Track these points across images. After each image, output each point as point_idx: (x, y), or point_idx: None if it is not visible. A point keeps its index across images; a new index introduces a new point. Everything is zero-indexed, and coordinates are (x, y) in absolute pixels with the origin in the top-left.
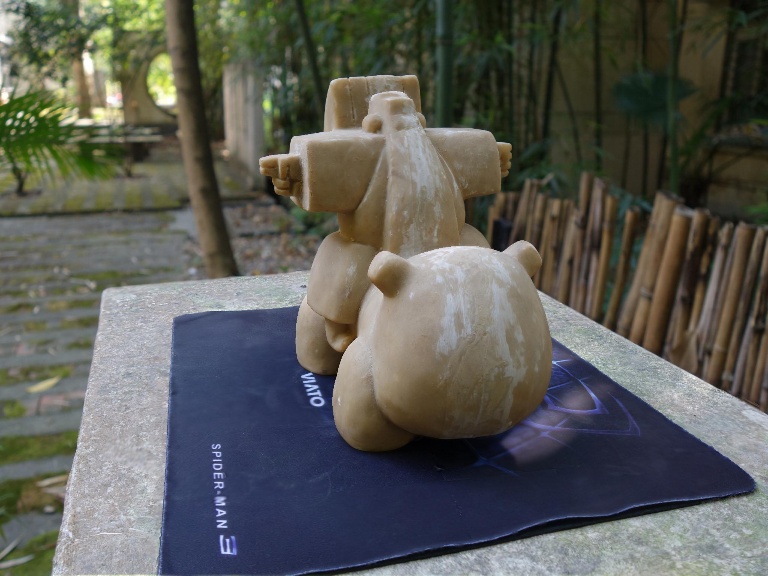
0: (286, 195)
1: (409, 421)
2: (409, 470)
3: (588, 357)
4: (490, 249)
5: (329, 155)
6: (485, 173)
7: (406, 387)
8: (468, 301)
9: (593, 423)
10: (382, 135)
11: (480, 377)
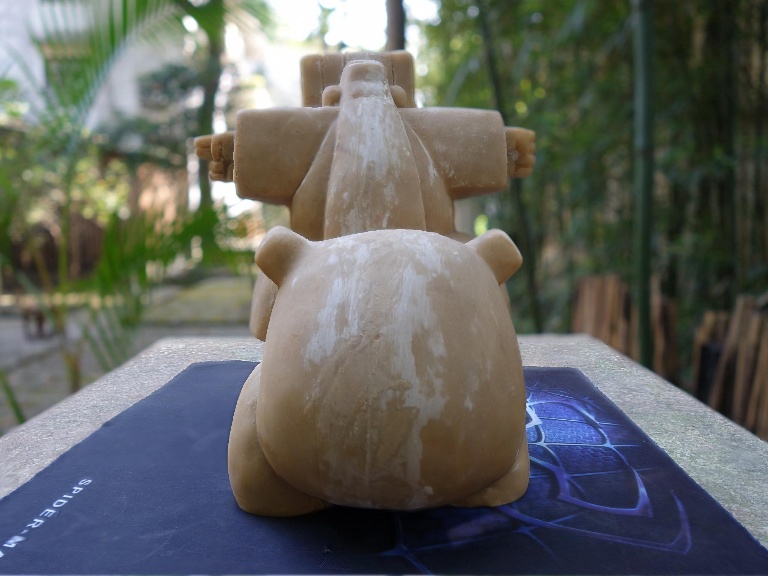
0: None
1: (282, 467)
2: (284, 545)
3: (672, 447)
4: None
5: (261, 126)
6: (482, 159)
7: (271, 411)
8: (362, 288)
9: (615, 526)
10: (338, 107)
11: (363, 402)
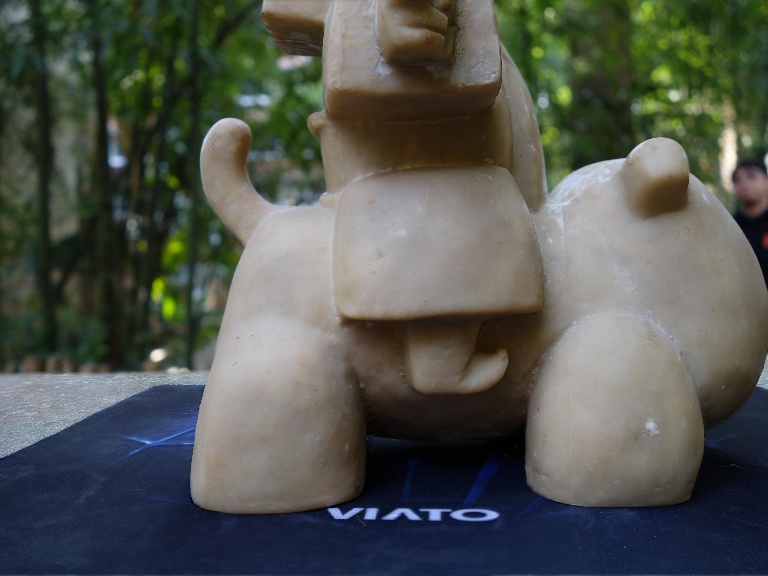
0: (438, 50)
1: (744, 394)
2: (745, 480)
3: None
4: None
5: None
6: None
7: (757, 332)
8: None
9: None
10: None
11: None
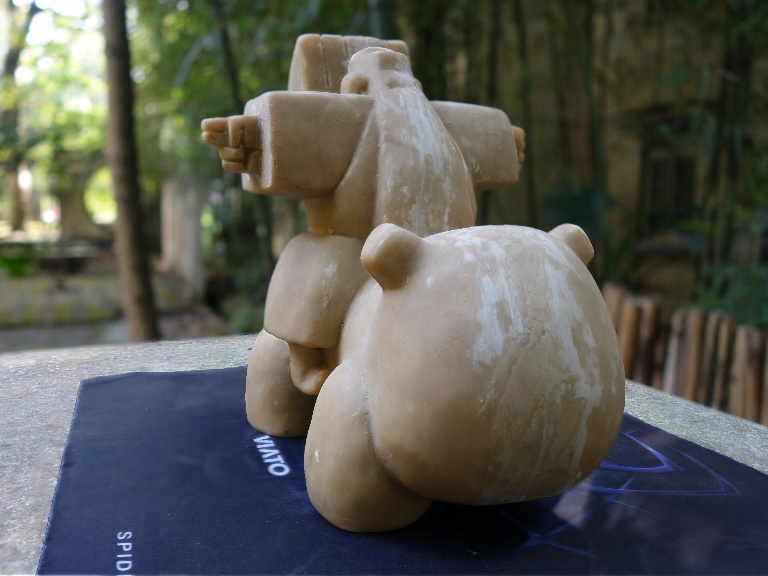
0: (238, 170)
1: (429, 476)
2: (430, 557)
3: None
4: None
5: (299, 111)
6: (499, 156)
7: (426, 420)
8: (514, 286)
9: (670, 482)
10: (369, 95)
11: (540, 398)
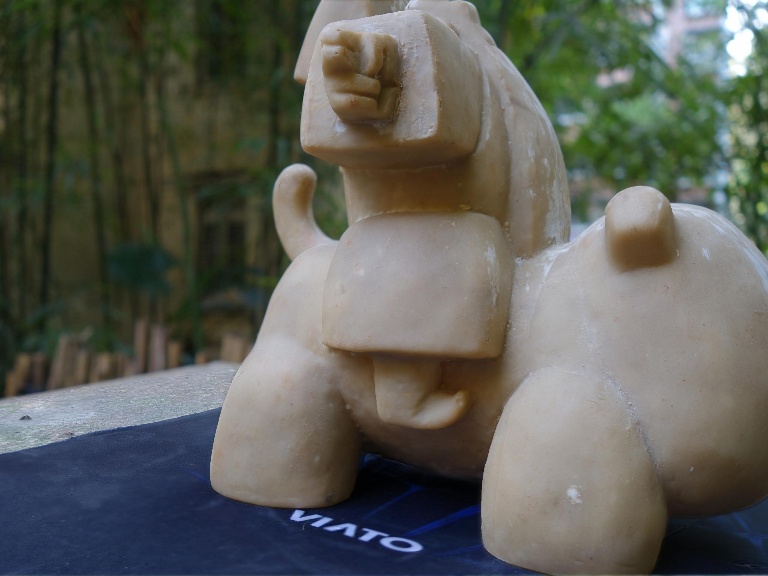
0: (369, 111)
1: (736, 483)
2: None
3: None
4: None
5: (449, 45)
6: None
7: (750, 413)
8: (762, 259)
9: None
10: None
11: None
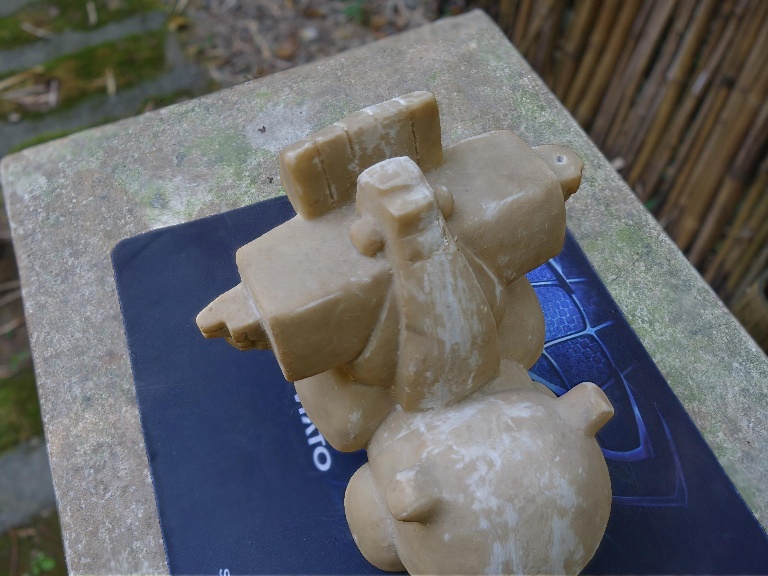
0: None
1: None
2: None
3: (632, 306)
4: (550, 441)
5: (307, 328)
6: (542, 247)
7: None
8: (520, 547)
9: (636, 482)
10: (386, 263)
11: None
